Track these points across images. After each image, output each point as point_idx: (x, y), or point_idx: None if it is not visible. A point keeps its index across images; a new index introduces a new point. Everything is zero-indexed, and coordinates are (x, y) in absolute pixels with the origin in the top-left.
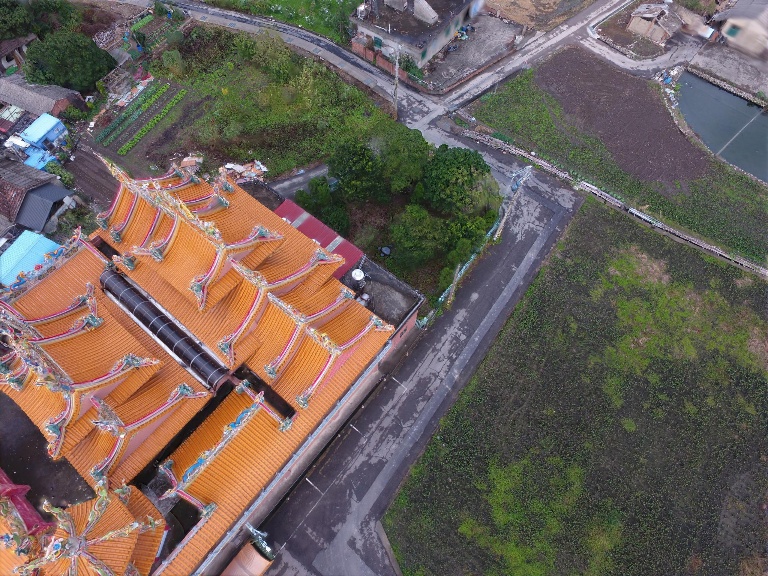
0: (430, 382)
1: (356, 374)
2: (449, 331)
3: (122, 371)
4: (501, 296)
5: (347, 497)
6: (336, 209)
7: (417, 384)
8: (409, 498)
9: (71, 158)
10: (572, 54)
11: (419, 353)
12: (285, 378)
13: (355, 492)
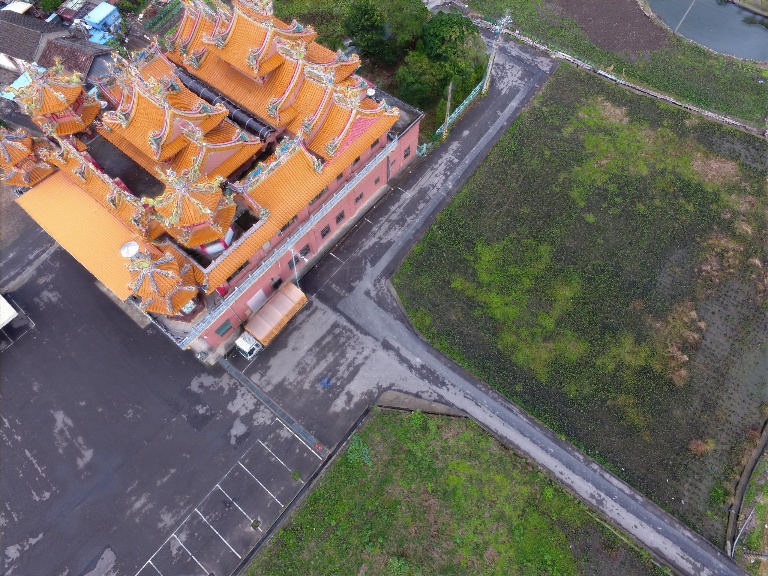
0: (429, 190)
1: (370, 143)
2: (445, 156)
3: (199, 114)
4: (488, 132)
5: (363, 264)
6: None
7: (418, 192)
8: (412, 266)
9: (126, 40)
10: None
11: (420, 171)
12: (317, 139)
13: (369, 261)
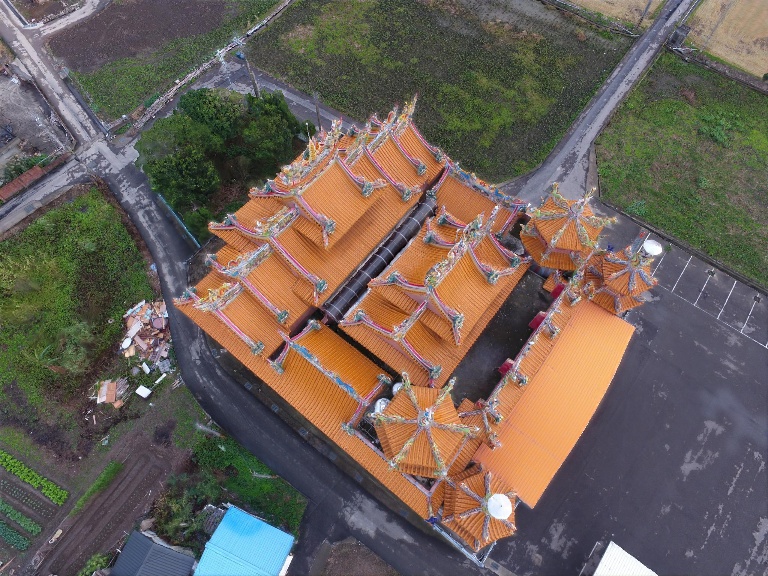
0: None
1: None
2: None
3: None
4: None
5: None
6: (223, 212)
7: None
8: None
9: None
10: (58, 43)
11: None
12: None
13: None
